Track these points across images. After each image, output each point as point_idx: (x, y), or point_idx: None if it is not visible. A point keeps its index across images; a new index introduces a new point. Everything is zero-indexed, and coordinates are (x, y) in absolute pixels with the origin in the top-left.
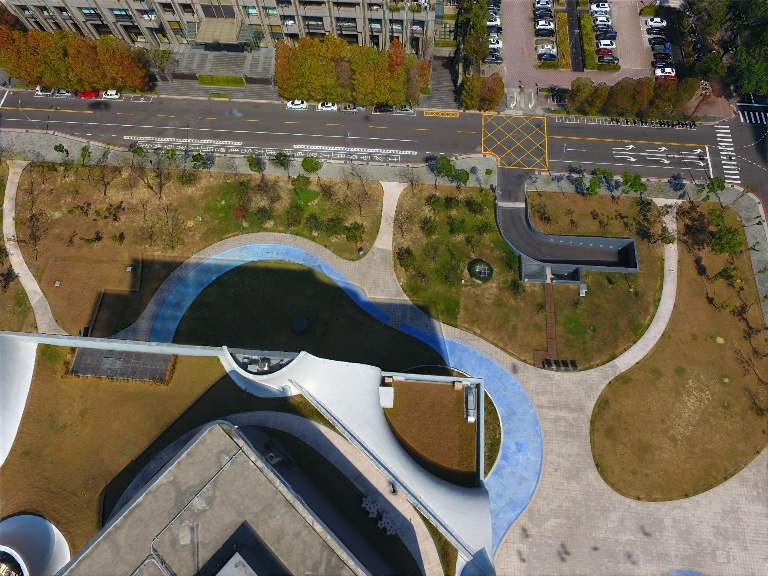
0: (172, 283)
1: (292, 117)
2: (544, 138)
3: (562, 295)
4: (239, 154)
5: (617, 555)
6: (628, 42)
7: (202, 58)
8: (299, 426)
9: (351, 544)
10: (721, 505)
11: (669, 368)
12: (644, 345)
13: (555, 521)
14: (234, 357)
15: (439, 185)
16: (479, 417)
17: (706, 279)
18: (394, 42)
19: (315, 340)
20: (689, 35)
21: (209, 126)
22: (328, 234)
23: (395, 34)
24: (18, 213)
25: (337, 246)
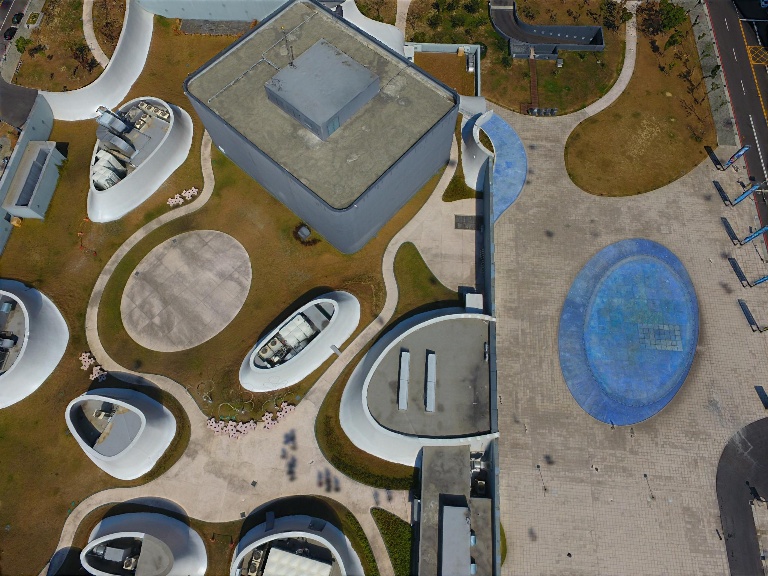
0: None
1: None
2: None
3: (543, 67)
4: None
5: (584, 230)
6: None
7: None
8: None
9: None
10: (666, 198)
11: (628, 113)
12: (608, 99)
13: (537, 209)
14: None
15: None
16: None
17: (659, 54)
18: None
19: None
20: None
21: None
22: None
23: None
24: (95, 22)
25: None
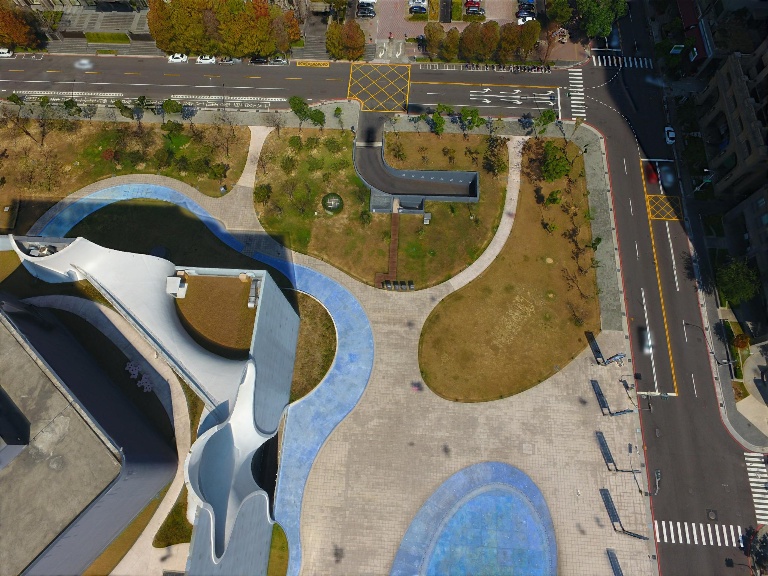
0: (46, 221)
1: (173, 70)
2: (407, 84)
3: (407, 224)
4: None
5: (431, 449)
6: None
7: (93, 18)
8: (82, 307)
9: (76, 380)
10: (532, 404)
11: (499, 286)
12: (478, 266)
13: (377, 421)
14: (19, 244)
15: (303, 128)
16: None
17: (543, 207)
18: None
19: None
20: None
21: (94, 80)
22: (195, 174)
23: None
24: None
25: (203, 185)
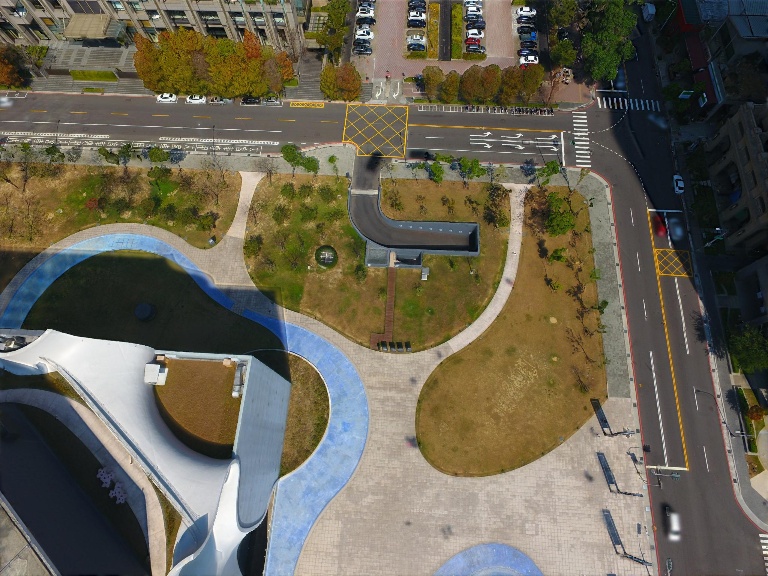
0: (26, 274)
1: (161, 110)
2: (404, 127)
3: (404, 279)
4: (105, 147)
5: (429, 529)
6: (497, 31)
7: (79, 54)
8: (52, 402)
9: (38, 508)
10: (536, 479)
11: (500, 348)
12: (479, 326)
13: (372, 497)
14: None
15: (297, 174)
16: (243, 392)
17: (546, 261)
18: (246, 34)
19: (159, 327)
20: (556, 23)
21: (79, 120)
22: (183, 224)
23: (259, 27)
24: None
25: (191, 235)
